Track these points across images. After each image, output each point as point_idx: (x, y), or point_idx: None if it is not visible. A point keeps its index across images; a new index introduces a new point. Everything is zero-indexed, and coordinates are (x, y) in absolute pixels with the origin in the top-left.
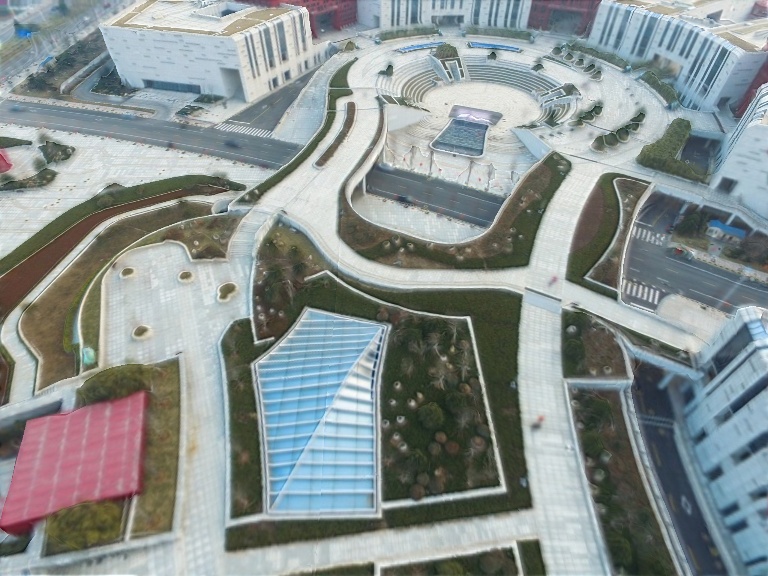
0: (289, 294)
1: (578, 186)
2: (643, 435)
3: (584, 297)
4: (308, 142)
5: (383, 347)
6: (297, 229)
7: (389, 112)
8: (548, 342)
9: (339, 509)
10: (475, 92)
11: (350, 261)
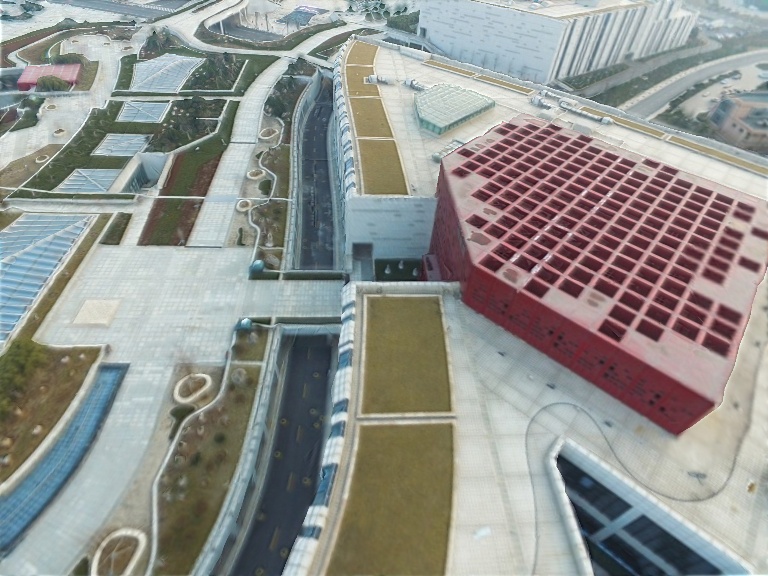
0: (157, 44)
1: (342, 30)
2: (321, 106)
3: (312, 59)
4: (191, 5)
5: (200, 64)
6: (173, 35)
7: (251, 0)
8: (283, 68)
9: (161, 91)
10: (320, 1)
11: (197, 43)
